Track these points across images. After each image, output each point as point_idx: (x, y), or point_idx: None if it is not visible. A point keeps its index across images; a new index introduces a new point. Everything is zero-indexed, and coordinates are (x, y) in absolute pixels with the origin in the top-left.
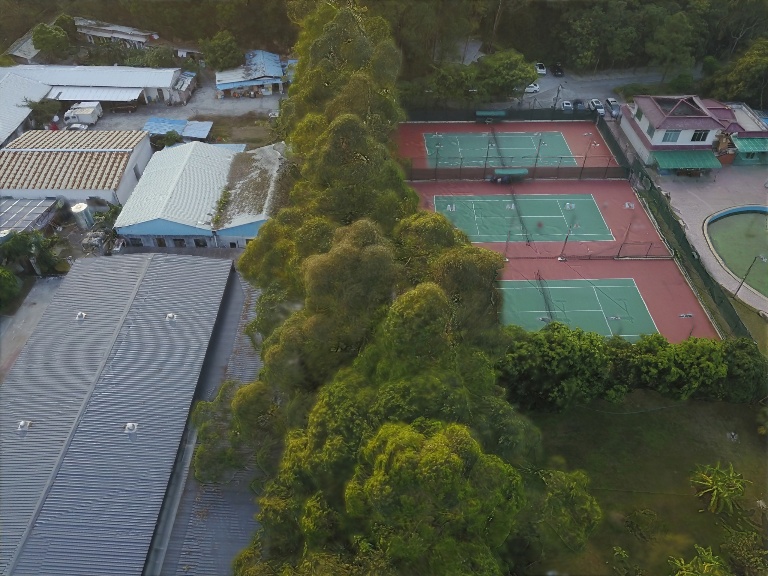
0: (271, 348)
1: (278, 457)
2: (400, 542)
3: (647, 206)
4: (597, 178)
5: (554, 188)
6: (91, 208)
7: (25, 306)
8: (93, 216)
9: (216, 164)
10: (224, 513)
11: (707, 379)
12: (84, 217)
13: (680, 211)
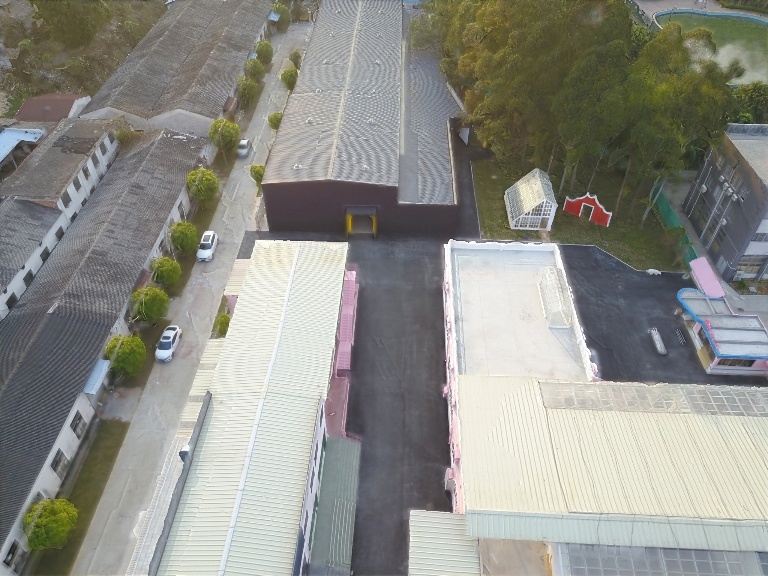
0: None
1: None
2: None
3: None
4: None
5: None
6: None
7: (289, 31)
8: (307, 4)
9: None
10: (424, 62)
11: (639, 42)
12: None
13: None
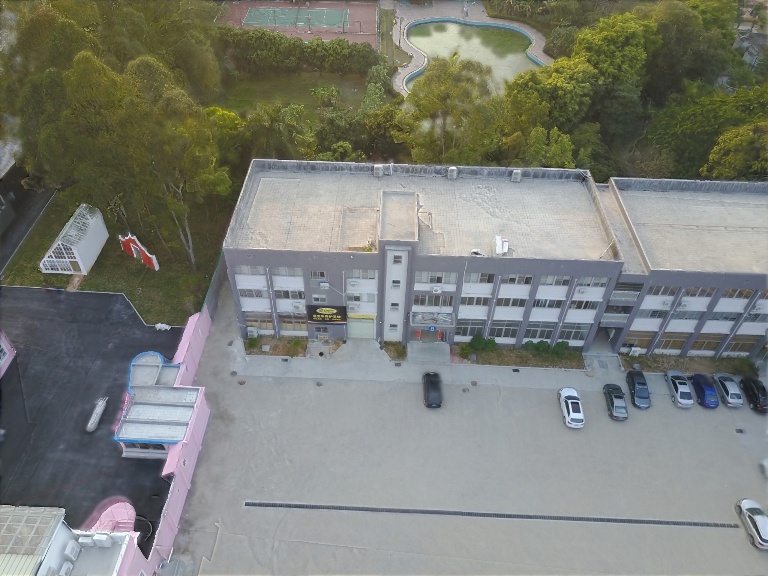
0: None
1: None
2: None
3: None
4: (357, 2)
5: (328, 6)
6: None
7: None
8: None
9: None
10: None
11: (337, 55)
12: None
13: (399, 18)
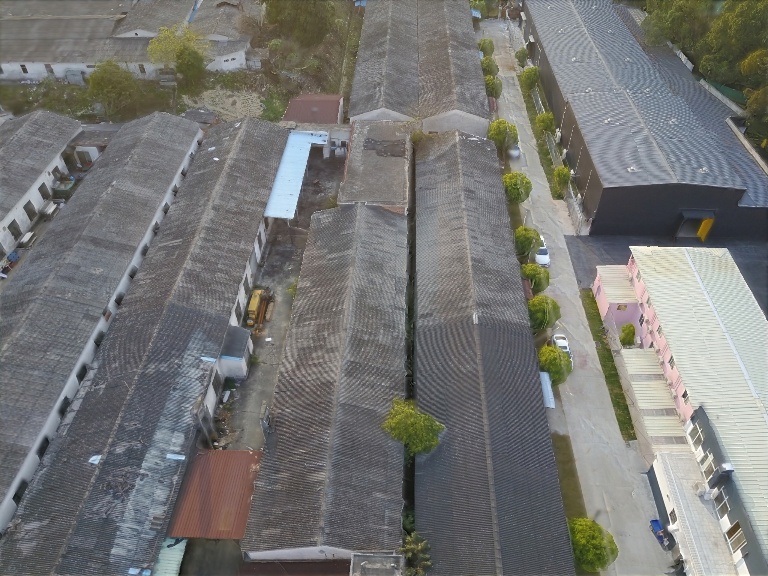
0: None
1: None
2: None
3: None
4: None
5: None
6: None
7: None
8: None
9: None
10: None
11: None
12: None
13: None
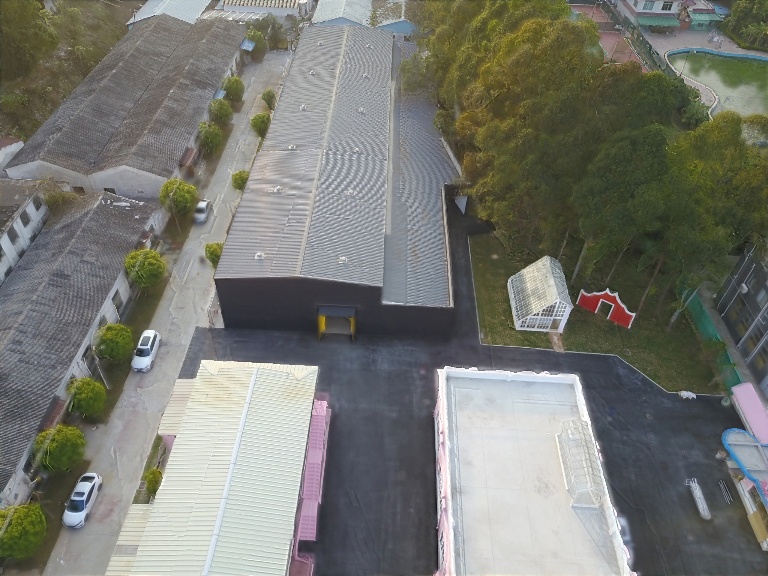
0: (458, 1)
1: (445, 79)
2: (534, 1)
3: (631, 43)
4: (600, 30)
5: None
6: (286, 23)
7: (265, 60)
8: (287, 28)
9: (364, 0)
10: (416, 110)
11: None
12: (305, 8)
13: None
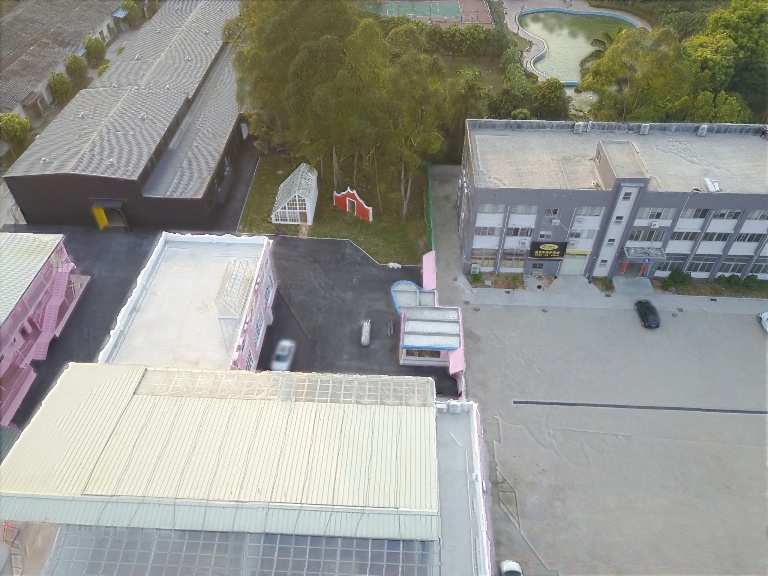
0: None
1: None
2: None
3: (487, 5)
4: None
5: None
6: None
7: None
8: None
9: None
10: None
11: (474, 40)
12: None
13: (507, 9)
